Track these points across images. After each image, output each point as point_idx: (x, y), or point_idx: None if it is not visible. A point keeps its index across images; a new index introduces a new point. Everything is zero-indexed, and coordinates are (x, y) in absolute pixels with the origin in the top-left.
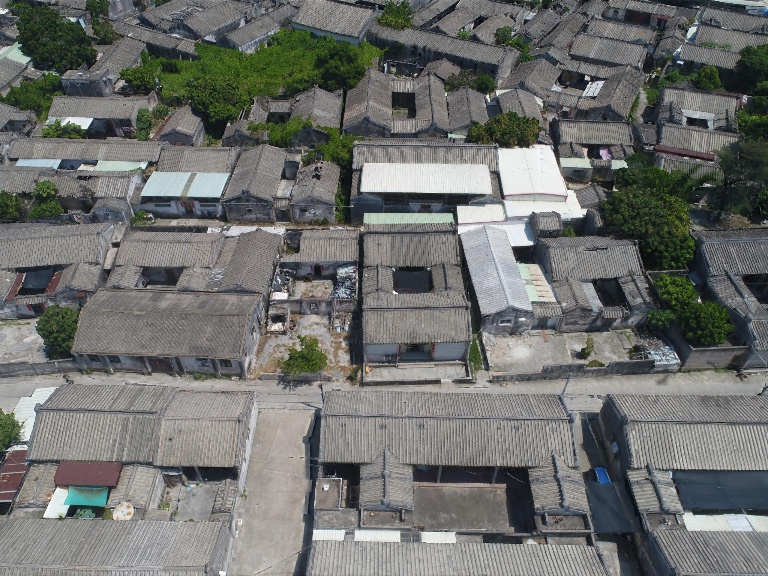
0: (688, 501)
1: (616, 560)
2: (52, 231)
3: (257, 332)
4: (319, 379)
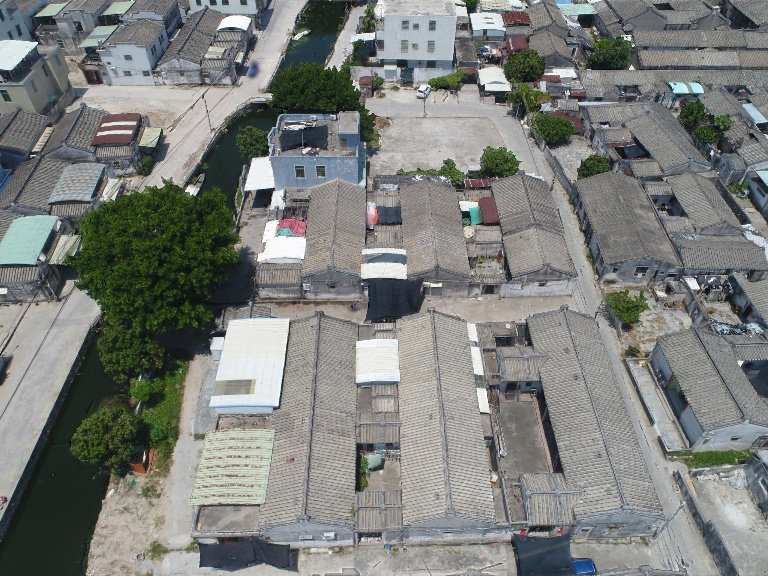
0: None
1: (500, 573)
2: (680, 139)
3: (647, 279)
4: (617, 329)
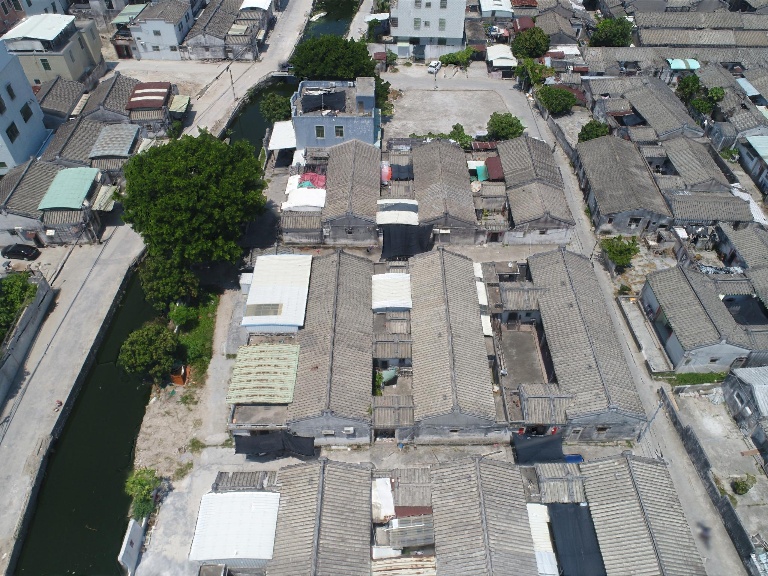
0: (557, 510)
1: None
2: (675, 108)
3: (640, 230)
4: (611, 272)
